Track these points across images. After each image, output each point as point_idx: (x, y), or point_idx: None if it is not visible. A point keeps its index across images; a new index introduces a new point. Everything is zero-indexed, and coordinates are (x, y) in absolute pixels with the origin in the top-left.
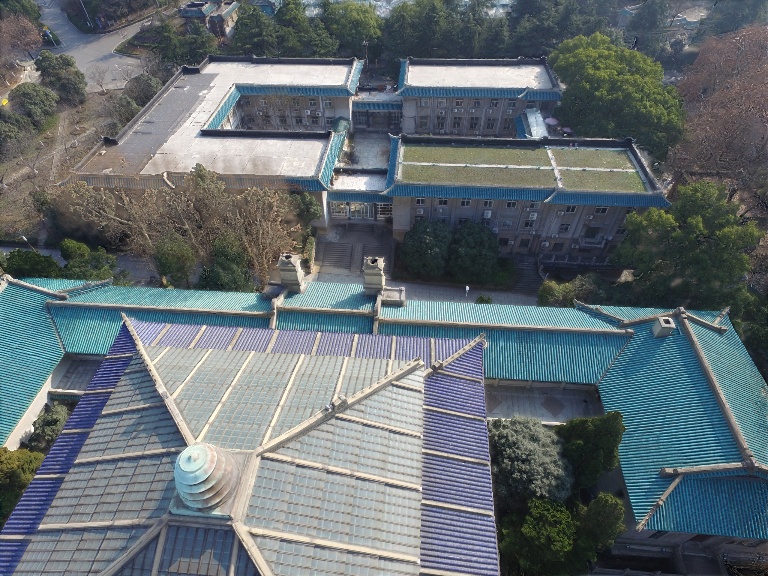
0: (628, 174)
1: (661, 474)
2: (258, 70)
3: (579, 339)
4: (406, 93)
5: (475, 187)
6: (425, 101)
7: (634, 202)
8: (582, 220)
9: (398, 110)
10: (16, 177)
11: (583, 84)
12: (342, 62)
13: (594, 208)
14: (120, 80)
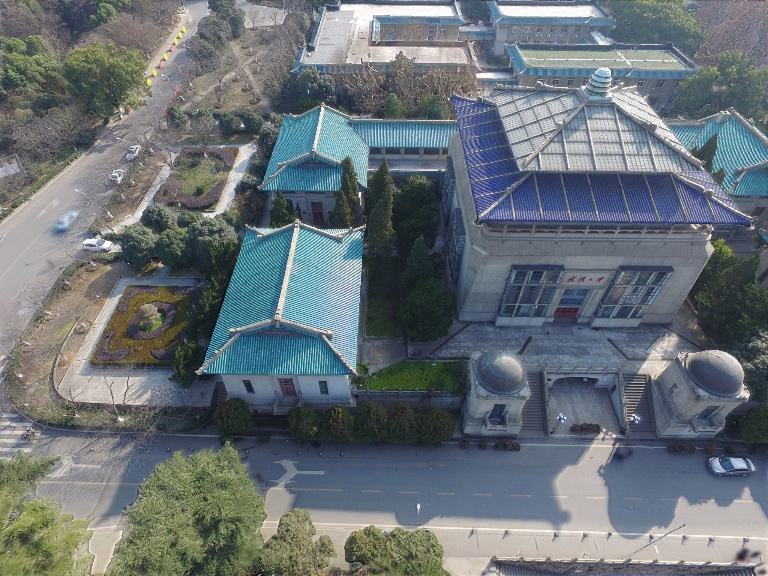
0: (674, 63)
1: (735, 173)
2: (383, 8)
3: (675, 129)
4: (503, 21)
5: (580, 69)
6: (515, 28)
7: (683, 76)
8: (647, 92)
9: (492, 37)
10: (224, 81)
11: (635, 9)
12: (444, 3)
13: (656, 82)
14: (265, 19)
